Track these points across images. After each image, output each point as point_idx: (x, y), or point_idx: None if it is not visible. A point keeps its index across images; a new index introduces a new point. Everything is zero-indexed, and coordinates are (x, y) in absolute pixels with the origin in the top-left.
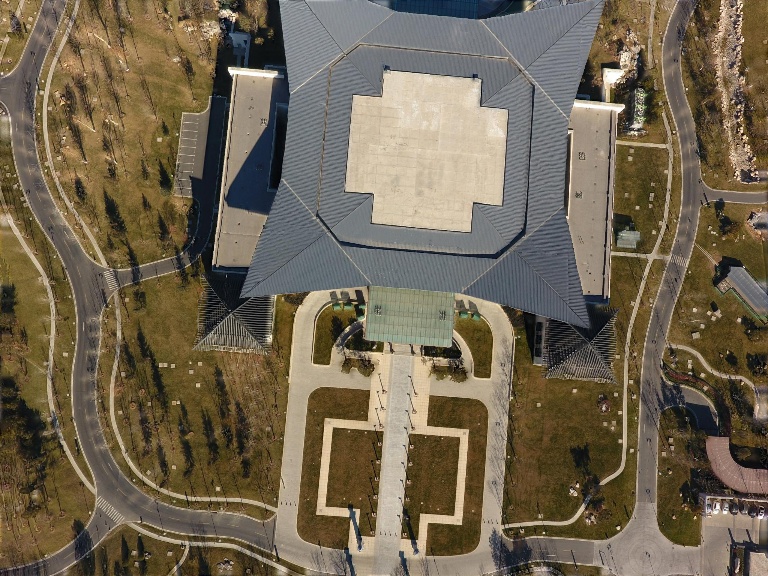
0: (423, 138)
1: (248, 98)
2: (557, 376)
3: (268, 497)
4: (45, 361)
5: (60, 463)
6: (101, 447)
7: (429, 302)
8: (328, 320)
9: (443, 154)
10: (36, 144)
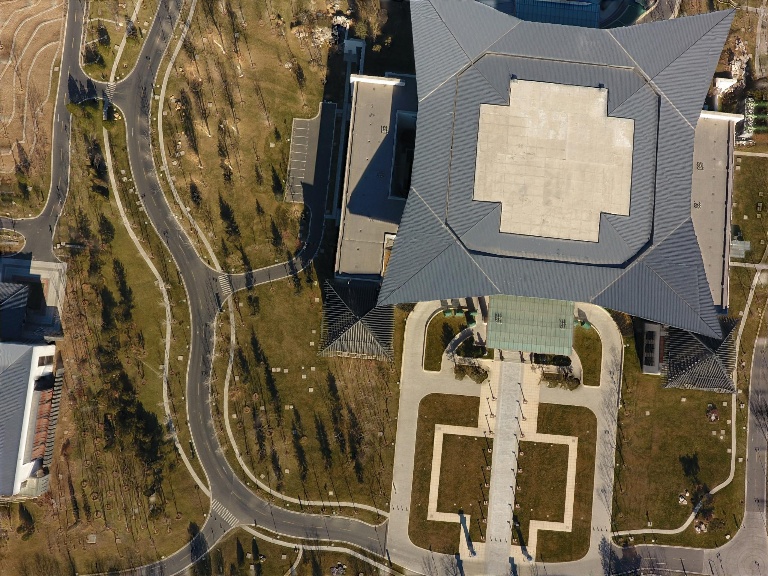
0: (551, 147)
1: (369, 105)
2: (677, 386)
3: (380, 502)
4: (161, 364)
5: (177, 466)
6: (215, 450)
7: (549, 310)
8: (439, 327)
9: (571, 164)
10: (151, 149)
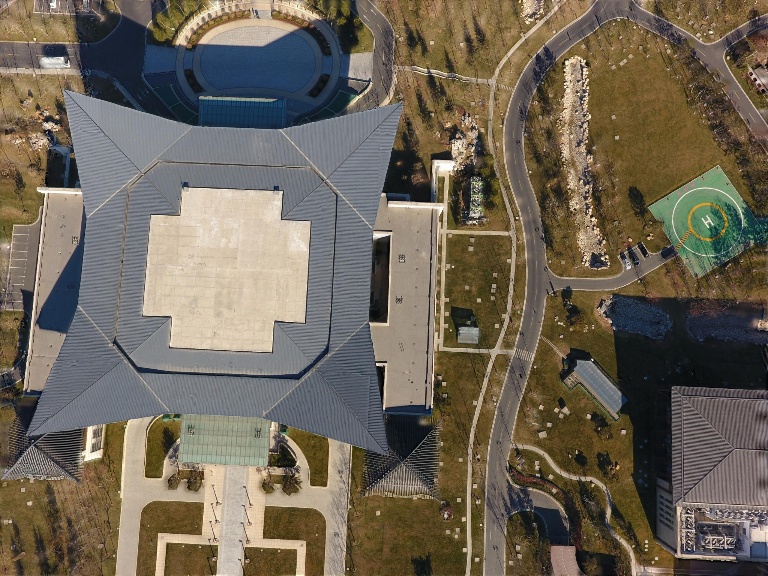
0: (222, 256)
1: (60, 216)
2: (378, 493)
3: None
4: None
5: None
6: None
7: (244, 419)
8: (159, 432)
9: (242, 272)
10: None
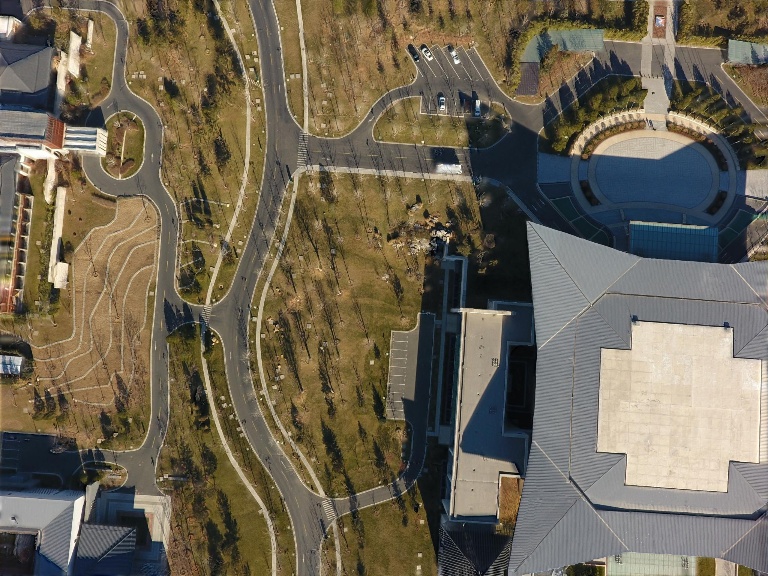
0: (676, 394)
1: (478, 337)
2: None
3: None
4: None
5: None
6: None
7: None
8: None
9: (697, 410)
10: (250, 373)
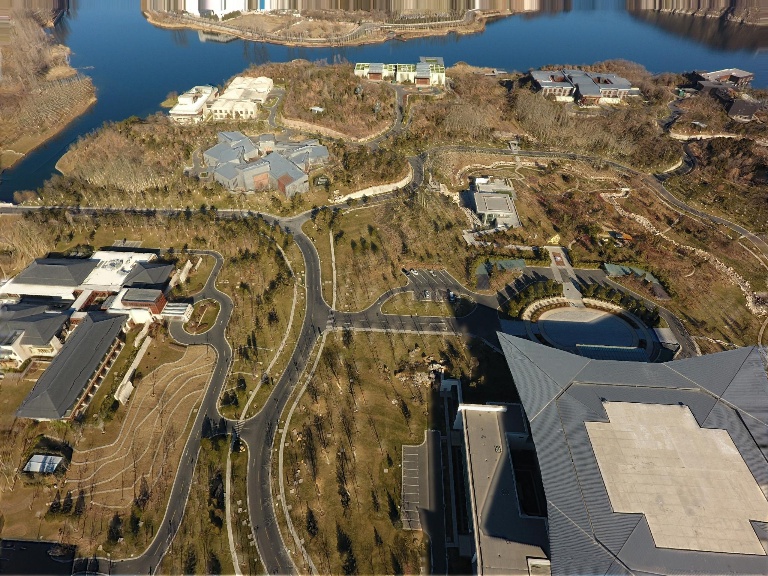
0: (665, 457)
1: (478, 429)
2: None
3: None
4: None
5: None
6: None
7: None
8: None
9: (691, 471)
10: (270, 478)
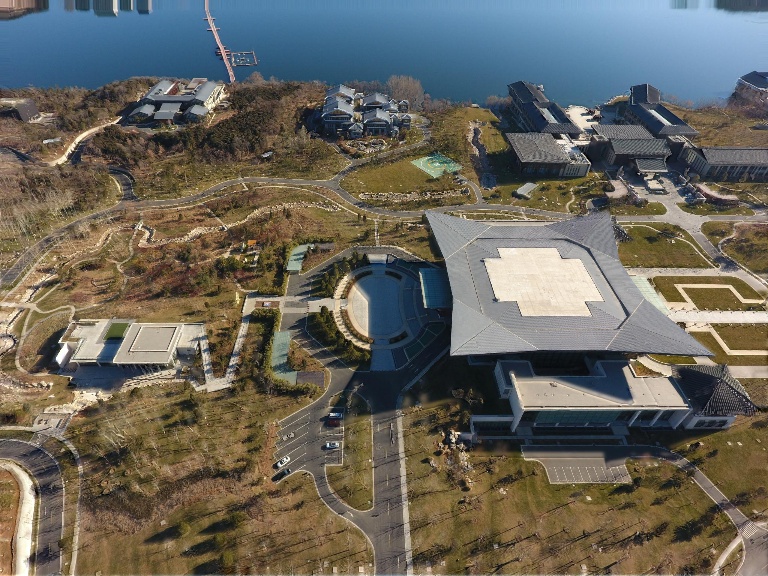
0: (535, 281)
1: (538, 398)
2: None
3: None
4: None
5: None
6: None
7: None
8: (660, 357)
9: (540, 272)
10: None
